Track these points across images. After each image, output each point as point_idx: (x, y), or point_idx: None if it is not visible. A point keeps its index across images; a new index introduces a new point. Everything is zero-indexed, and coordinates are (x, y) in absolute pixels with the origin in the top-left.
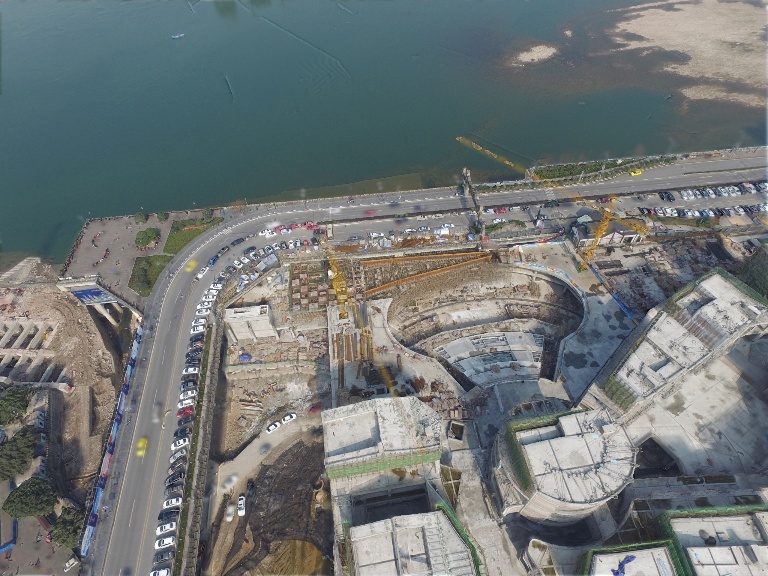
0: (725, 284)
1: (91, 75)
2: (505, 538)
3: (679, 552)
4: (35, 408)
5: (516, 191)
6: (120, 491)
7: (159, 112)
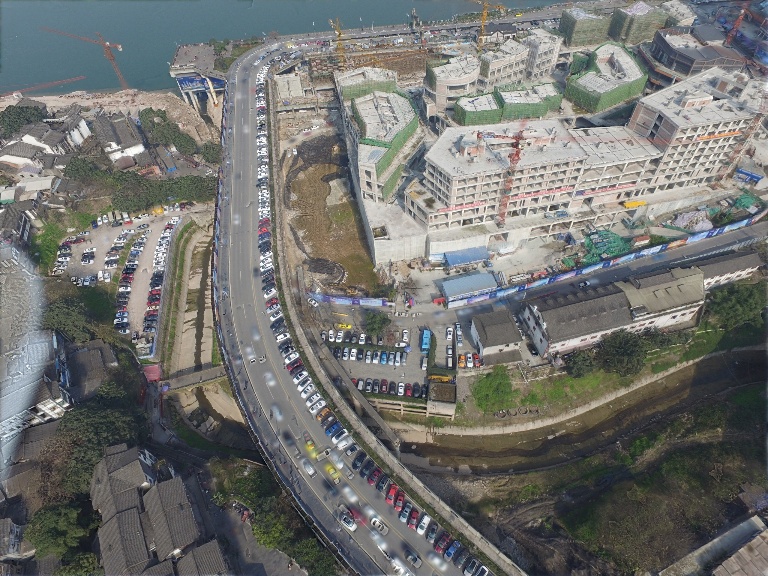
0: (544, 32)
1: (136, 1)
2: (429, 131)
3: (497, 93)
4: None
5: (445, 25)
6: (234, 132)
7: (202, 9)
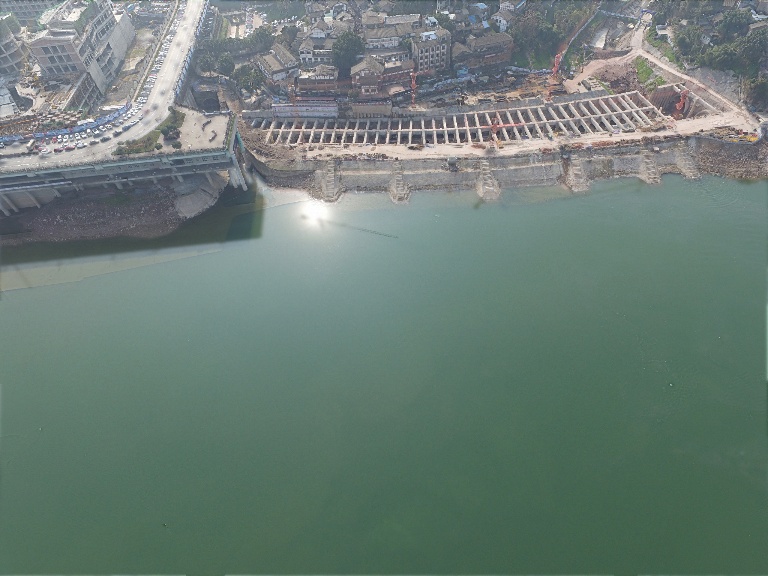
0: None
1: None
2: None
3: None
4: (251, 99)
5: None
6: None
7: (201, 359)
